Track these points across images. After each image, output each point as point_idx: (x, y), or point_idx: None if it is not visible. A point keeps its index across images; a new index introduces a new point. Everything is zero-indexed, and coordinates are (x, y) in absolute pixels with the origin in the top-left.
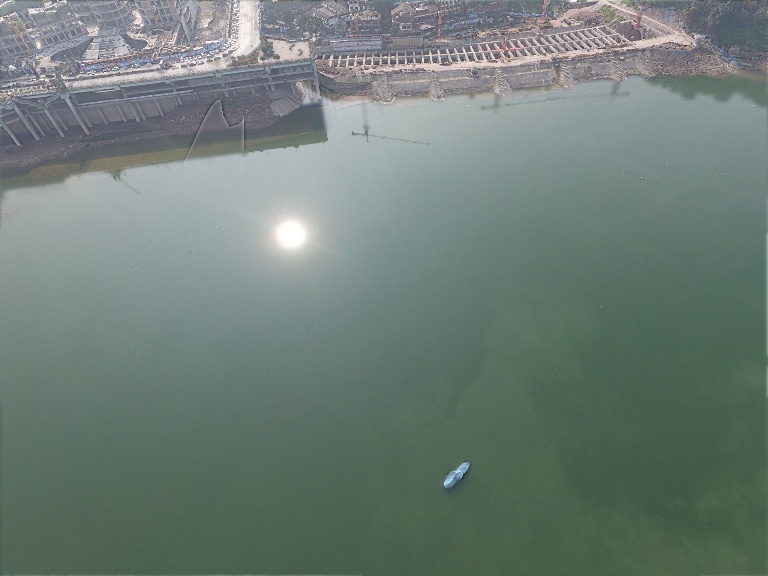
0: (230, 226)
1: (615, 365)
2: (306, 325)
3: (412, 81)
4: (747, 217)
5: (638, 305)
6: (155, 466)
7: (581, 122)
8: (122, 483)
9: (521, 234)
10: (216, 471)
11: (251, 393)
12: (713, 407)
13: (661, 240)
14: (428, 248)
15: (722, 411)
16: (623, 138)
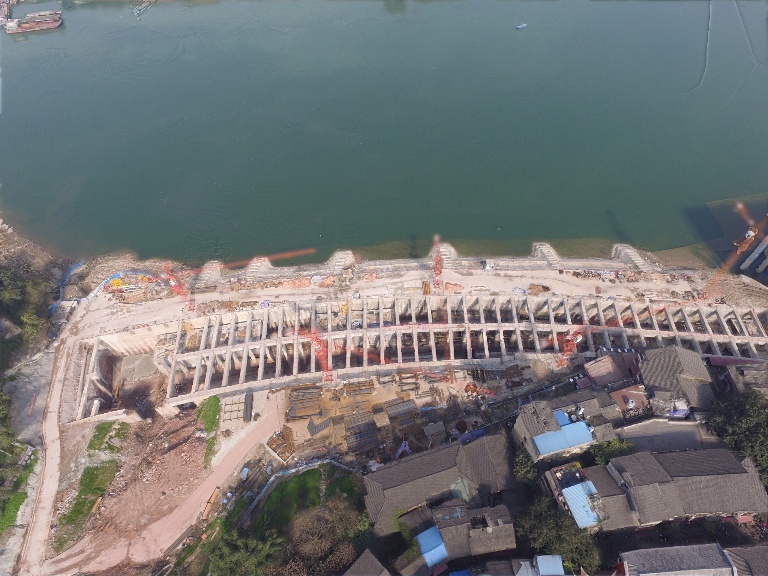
0: (710, 103)
1: (440, 51)
2: (610, 69)
3: (593, 264)
4: (302, 103)
5: (413, 68)
6: (654, 36)
7: (368, 186)
8: (665, 33)
9: (471, 96)
10: (624, 28)
11: (625, 49)
12: (405, 42)
13: (378, 87)
14: (541, 89)
15: (402, 41)
16: (338, 166)
